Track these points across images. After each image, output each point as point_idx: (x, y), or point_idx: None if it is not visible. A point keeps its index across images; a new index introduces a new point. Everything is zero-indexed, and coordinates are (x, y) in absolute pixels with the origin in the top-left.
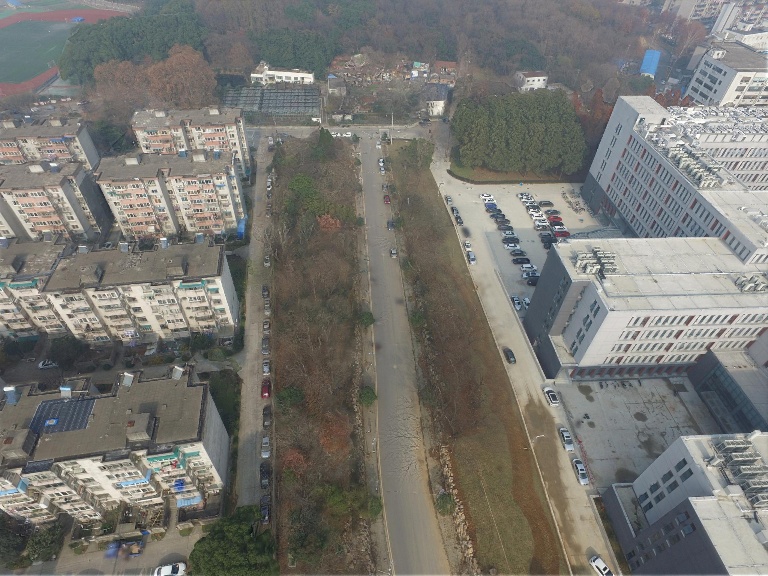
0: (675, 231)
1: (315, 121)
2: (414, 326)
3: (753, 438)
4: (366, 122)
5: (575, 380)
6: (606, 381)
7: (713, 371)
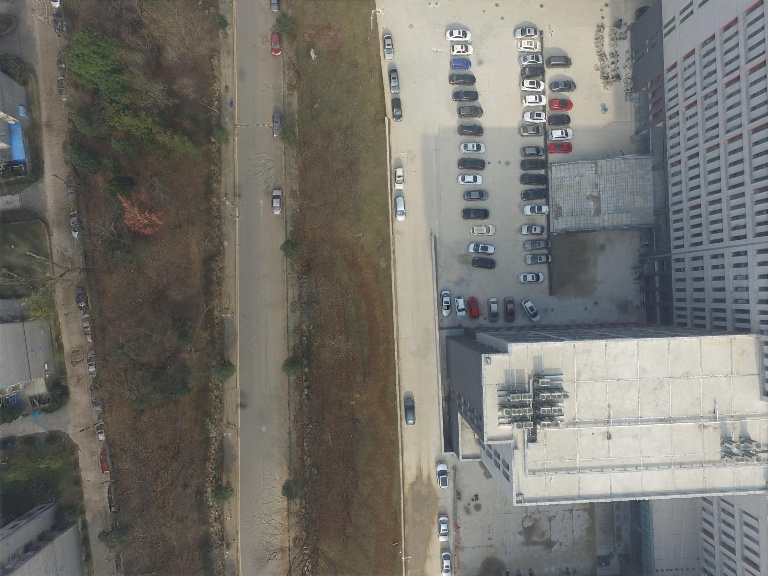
0: (715, 254)
1: None
2: (289, 375)
3: None
4: None
5: None
6: None
7: None
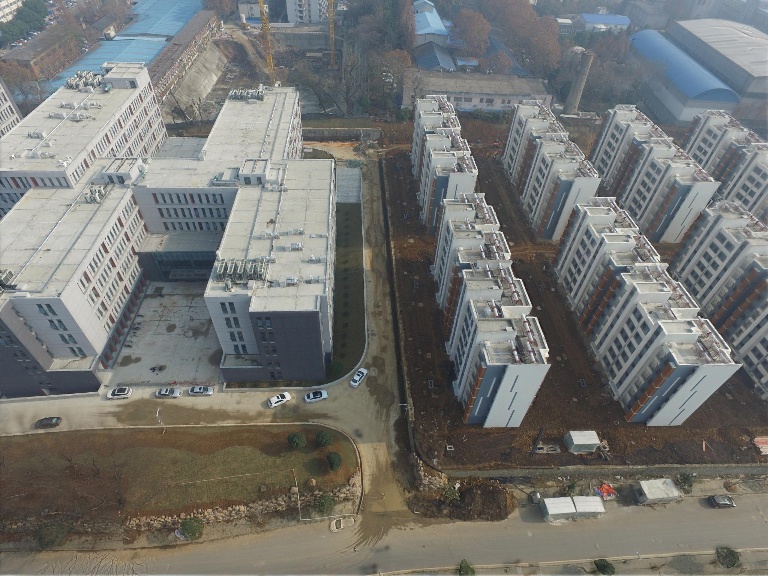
0: None
1: None
2: None
3: (220, 257)
4: None
5: (112, 366)
6: (126, 341)
7: (156, 261)
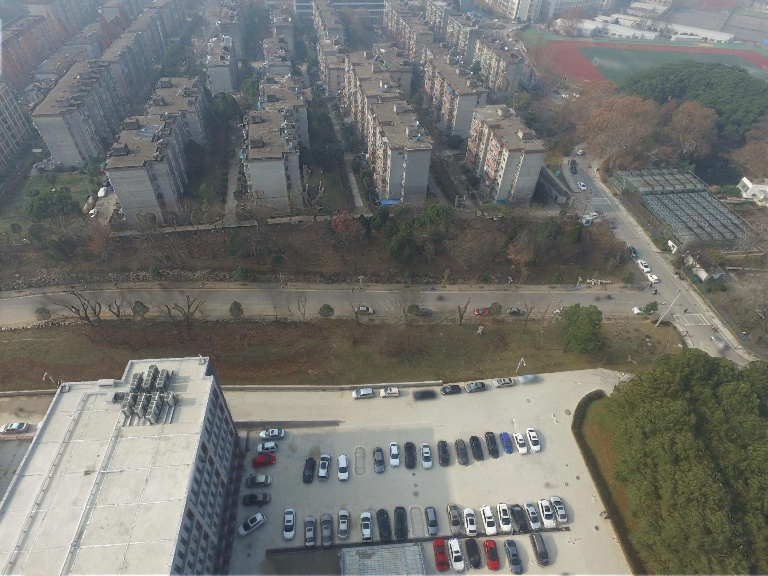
0: None
1: (670, 246)
2: None
3: None
4: (709, 296)
5: None
6: None
7: None
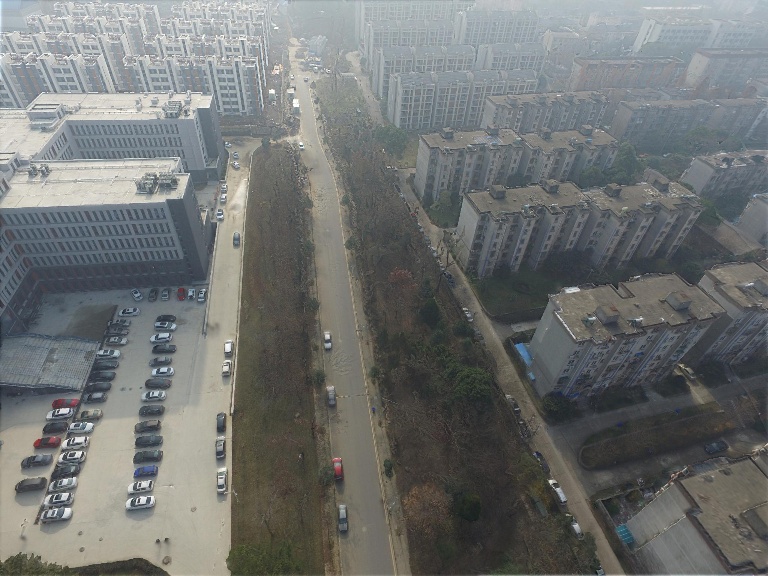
0: None
1: None
2: None
3: None
4: None
5: None
6: None
7: None
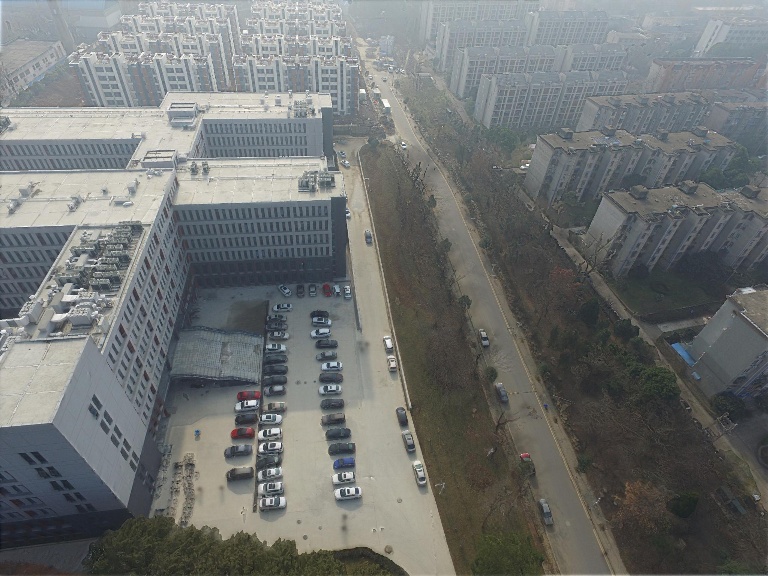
0: None
1: None
2: None
3: None
4: None
5: None
6: None
7: None
